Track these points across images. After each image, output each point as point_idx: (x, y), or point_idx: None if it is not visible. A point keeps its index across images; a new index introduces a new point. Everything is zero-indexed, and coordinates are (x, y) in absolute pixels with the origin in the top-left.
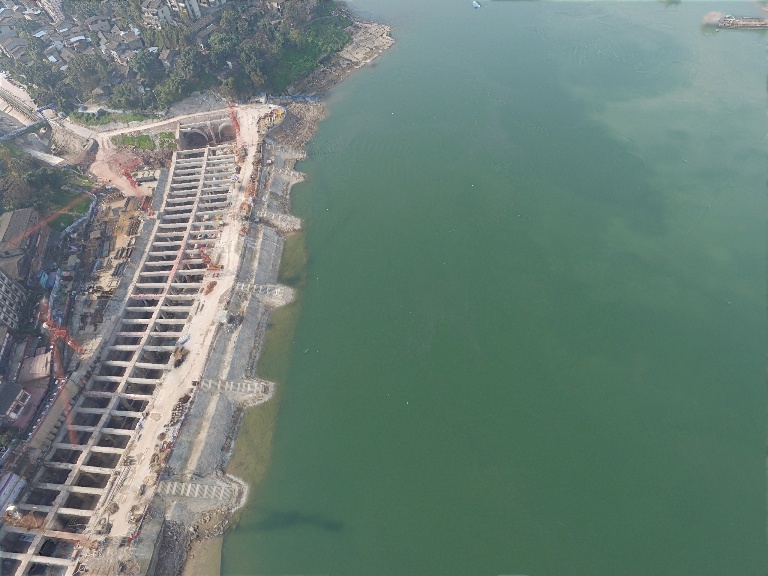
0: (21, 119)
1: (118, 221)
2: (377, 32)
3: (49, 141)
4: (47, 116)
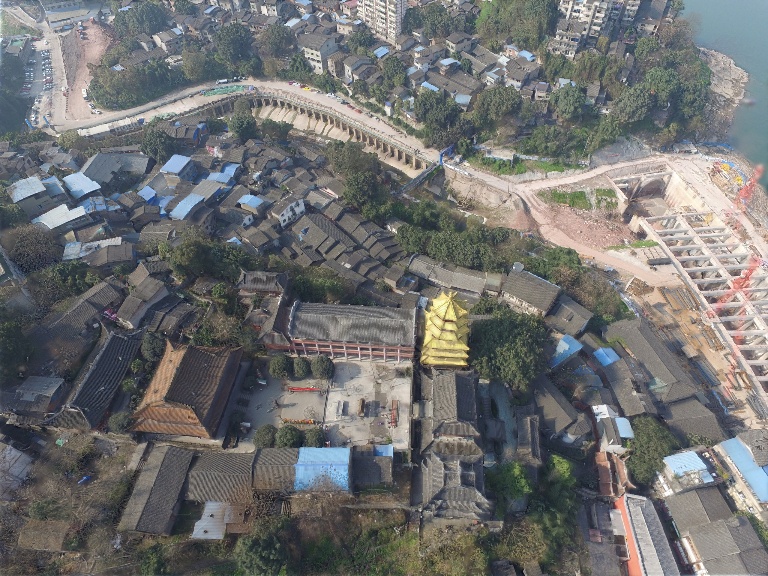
0: (379, 156)
1: (680, 326)
2: (725, 61)
3: (441, 190)
4: (437, 159)
